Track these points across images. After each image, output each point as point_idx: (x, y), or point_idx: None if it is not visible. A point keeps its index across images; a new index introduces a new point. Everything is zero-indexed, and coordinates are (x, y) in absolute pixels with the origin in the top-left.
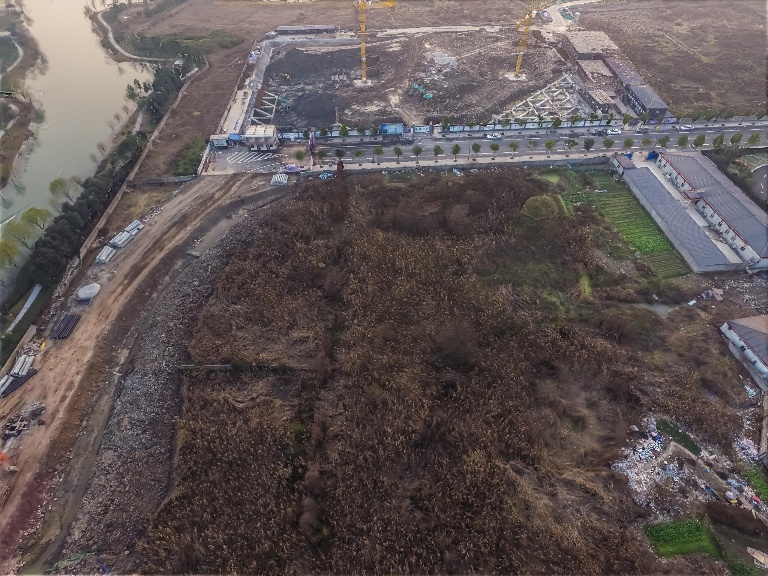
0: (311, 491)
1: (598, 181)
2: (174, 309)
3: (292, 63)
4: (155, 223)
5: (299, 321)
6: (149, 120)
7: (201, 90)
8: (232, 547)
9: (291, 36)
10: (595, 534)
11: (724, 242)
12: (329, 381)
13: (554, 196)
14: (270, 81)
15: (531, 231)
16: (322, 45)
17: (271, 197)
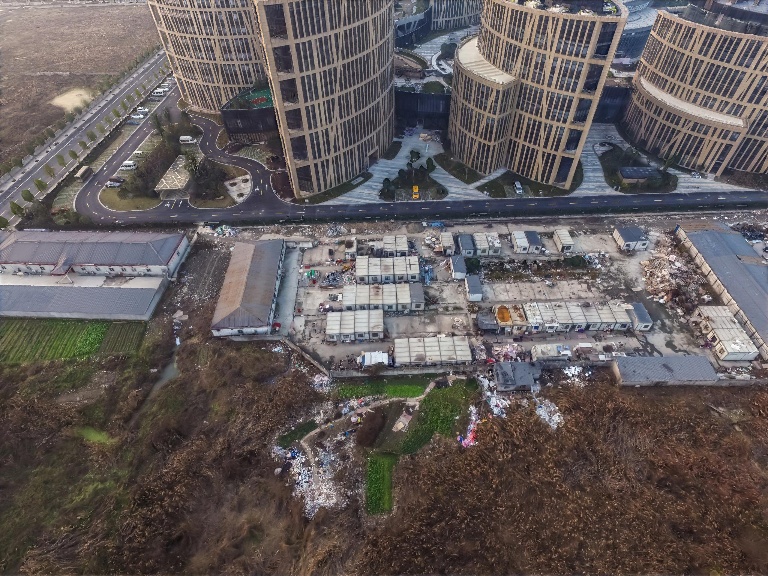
0: None
1: None
2: None
3: None
4: None
5: None
6: None
7: None
8: None
9: None
10: (366, 573)
11: (132, 278)
12: None
13: None
14: None
15: None
16: None
17: None
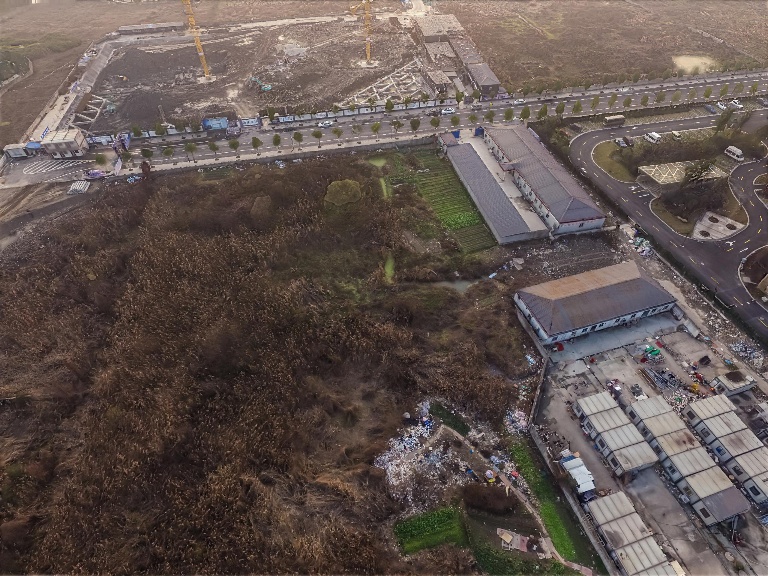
0: (9, 544)
1: (423, 161)
2: None
3: (130, 63)
4: None
5: (59, 343)
6: None
7: (18, 98)
8: None
9: (136, 36)
10: (337, 541)
11: (533, 211)
12: (78, 408)
13: (374, 180)
14: (105, 84)
15: (342, 218)
16: (168, 43)
17: (67, 208)
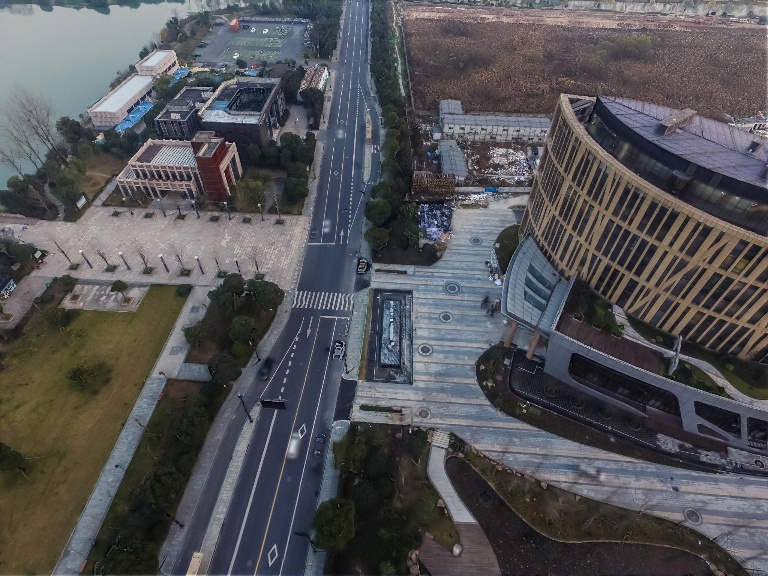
0: None
1: None
2: None
3: None
4: None
5: None
6: None
7: None
8: None
9: None
10: None
11: None
12: None
13: None
14: None
15: None
16: None
17: None
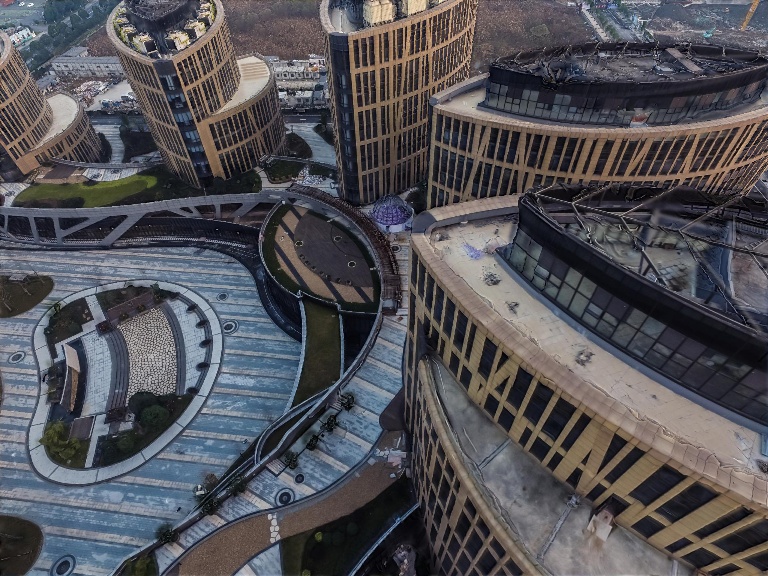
0: None
1: None
2: None
3: None
4: None
5: None
6: None
7: None
8: None
9: None
10: None
11: None
12: None
13: None
14: None
15: None
16: None
17: None
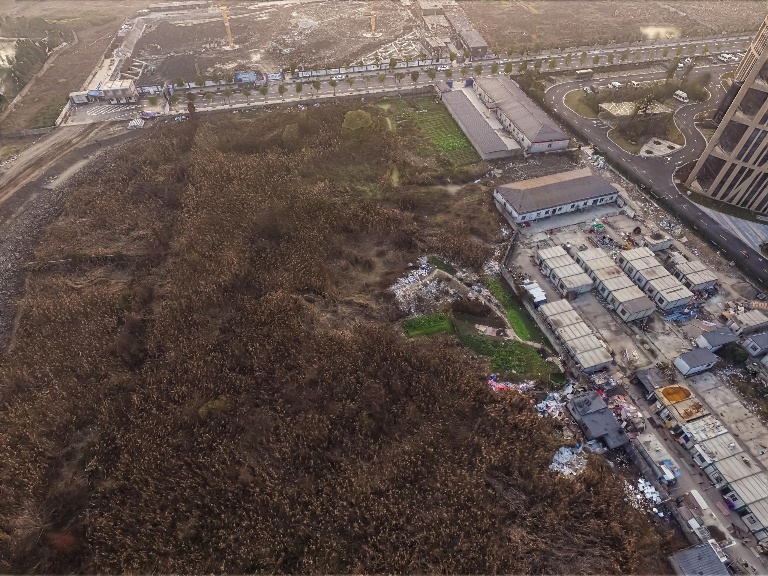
0: (130, 329)
1: (422, 105)
2: (24, 227)
3: (162, 34)
4: (11, 167)
5: (140, 224)
6: (12, 88)
7: (68, 61)
8: (58, 375)
9: (164, 12)
10: (361, 330)
11: (512, 138)
12: (162, 262)
13: (381, 118)
14: (141, 52)
15: (356, 143)
16: (194, 18)
17: (128, 139)
